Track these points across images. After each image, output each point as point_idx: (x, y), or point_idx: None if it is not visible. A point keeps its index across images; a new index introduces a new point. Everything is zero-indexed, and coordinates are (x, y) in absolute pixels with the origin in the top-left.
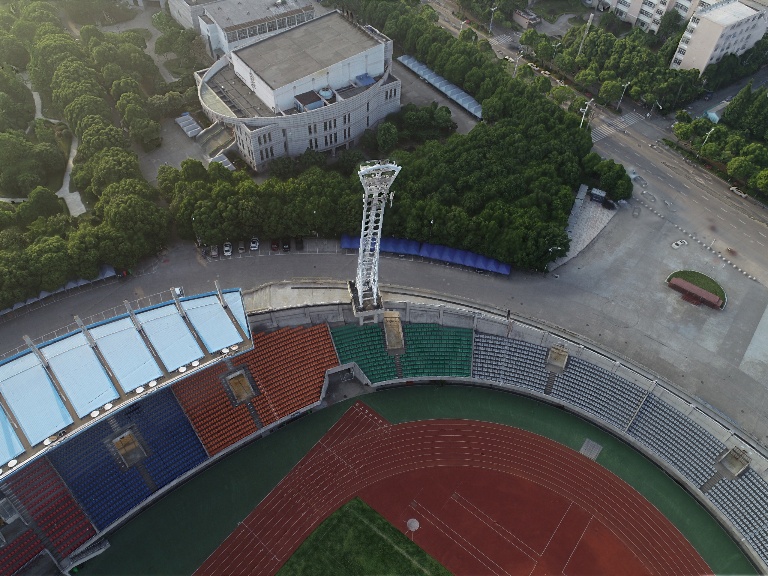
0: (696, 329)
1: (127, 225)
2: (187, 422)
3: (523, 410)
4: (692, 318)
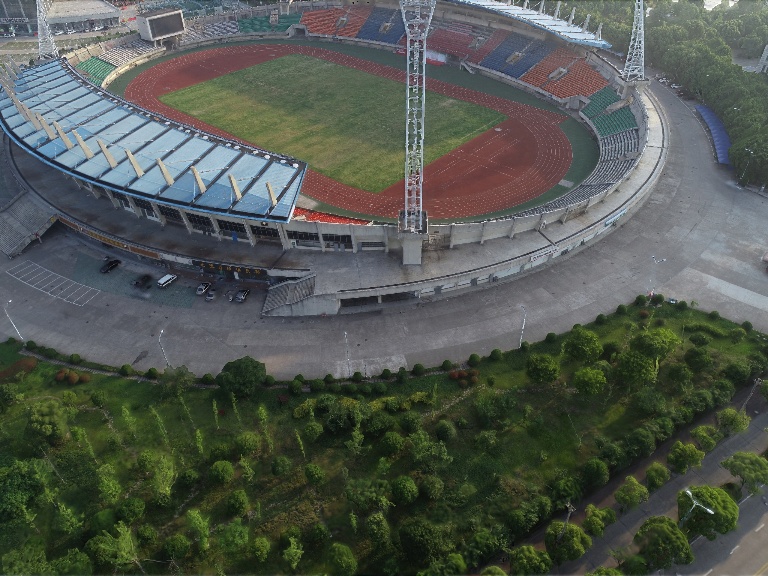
0: (726, 252)
1: (648, 36)
2: None
3: (587, 163)
4: (740, 253)
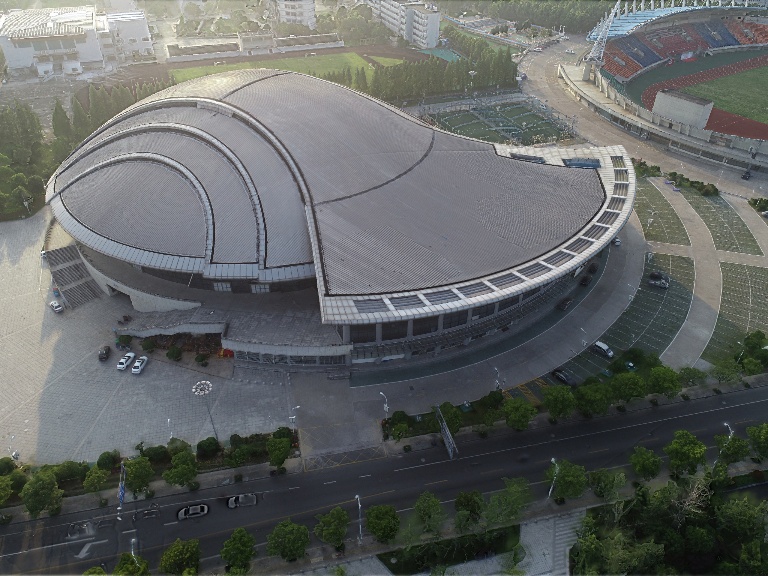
0: None
1: None
2: (733, 36)
3: None
4: None
